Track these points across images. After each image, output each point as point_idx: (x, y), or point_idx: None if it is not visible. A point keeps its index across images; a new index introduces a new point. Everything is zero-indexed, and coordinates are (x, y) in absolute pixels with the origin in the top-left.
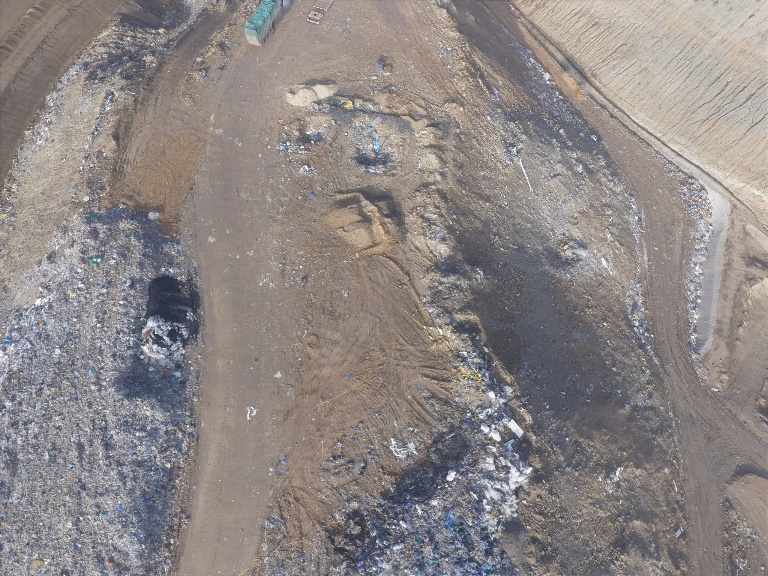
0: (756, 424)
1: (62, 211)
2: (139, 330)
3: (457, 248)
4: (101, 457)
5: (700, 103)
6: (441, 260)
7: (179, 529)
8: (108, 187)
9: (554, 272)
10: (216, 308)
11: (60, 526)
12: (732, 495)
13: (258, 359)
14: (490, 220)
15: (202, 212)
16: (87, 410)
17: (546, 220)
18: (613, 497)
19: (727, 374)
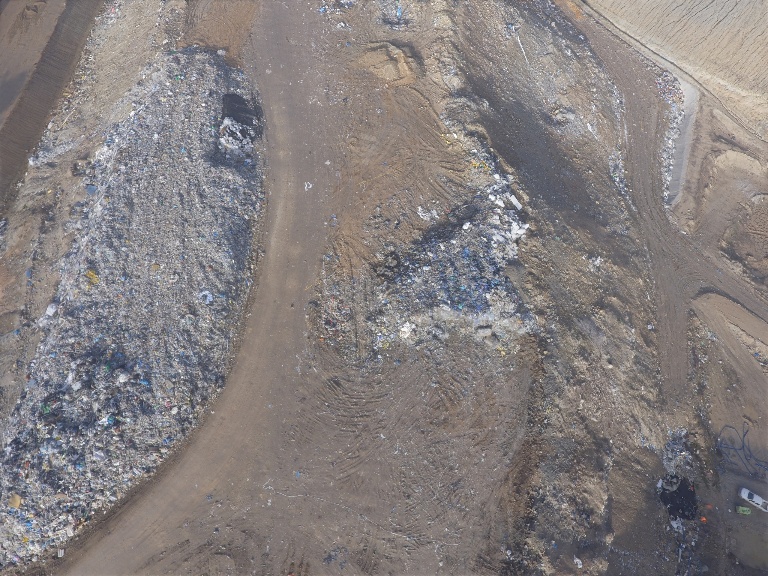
0: (718, 258)
1: (144, 55)
2: (218, 126)
3: (467, 83)
4: (197, 202)
5: (673, 7)
6: (454, 91)
7: (257, 259)
8: (183, 33)
9: (547, 127)
10: (276, 118)
11: (170, 244)
12: (696, 307)
13: (311, 152)
14: (493, 76)
15: (260, 52)
16: (183, 173)
17: (540, 90)
18: (594, 275)
19: (694, 220)
